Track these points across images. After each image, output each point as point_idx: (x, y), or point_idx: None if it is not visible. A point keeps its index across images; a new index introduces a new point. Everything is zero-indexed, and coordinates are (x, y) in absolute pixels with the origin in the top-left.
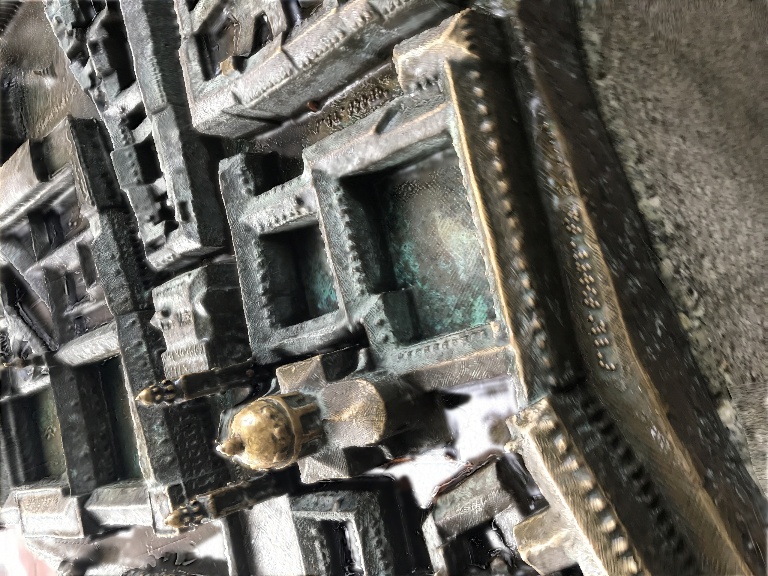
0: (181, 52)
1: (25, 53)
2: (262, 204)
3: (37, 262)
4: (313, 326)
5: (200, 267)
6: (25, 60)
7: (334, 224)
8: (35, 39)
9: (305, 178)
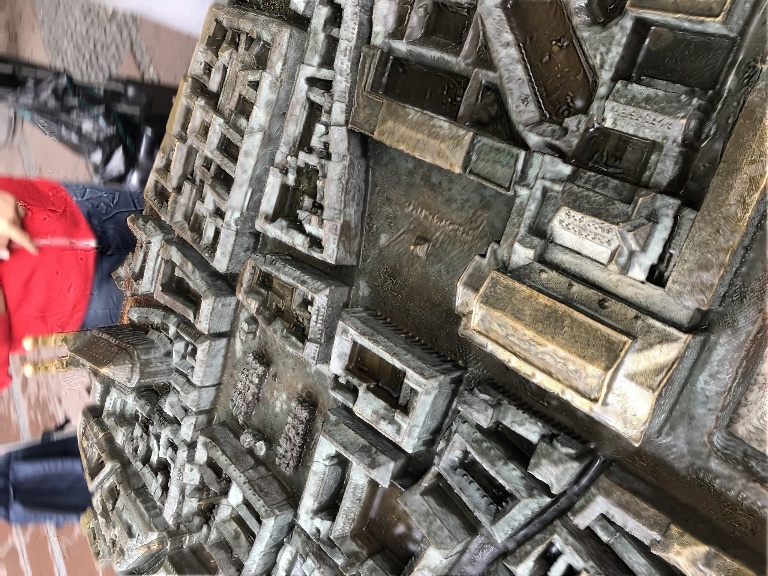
0: (270, 68)
1: (442, 308)
2: None
3: (474, 71)
4: None
5: None
6: (446, 304)
7: None
8: (422, 297)
9: None
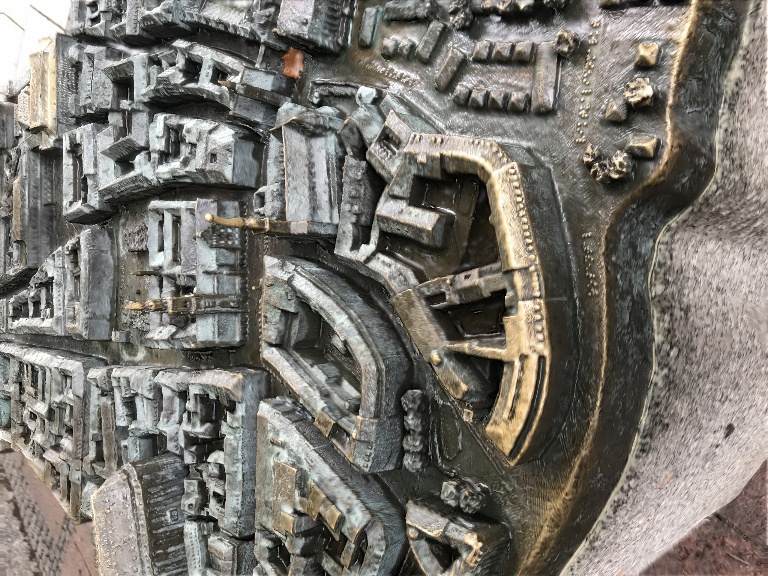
0: None
1: None
2: (11, 367)
3: None
4: (0, 373)
5: (5, 332)
6: None
7: (7, 393)
8: None
9: (13, 386)
